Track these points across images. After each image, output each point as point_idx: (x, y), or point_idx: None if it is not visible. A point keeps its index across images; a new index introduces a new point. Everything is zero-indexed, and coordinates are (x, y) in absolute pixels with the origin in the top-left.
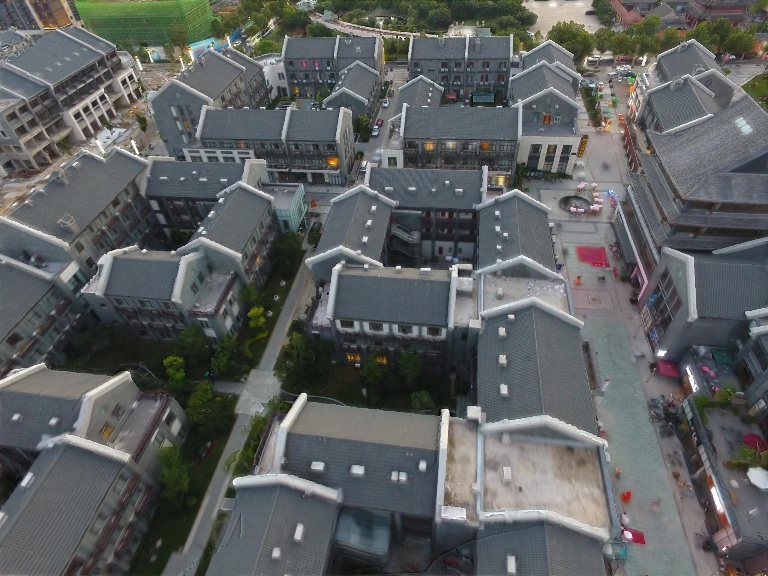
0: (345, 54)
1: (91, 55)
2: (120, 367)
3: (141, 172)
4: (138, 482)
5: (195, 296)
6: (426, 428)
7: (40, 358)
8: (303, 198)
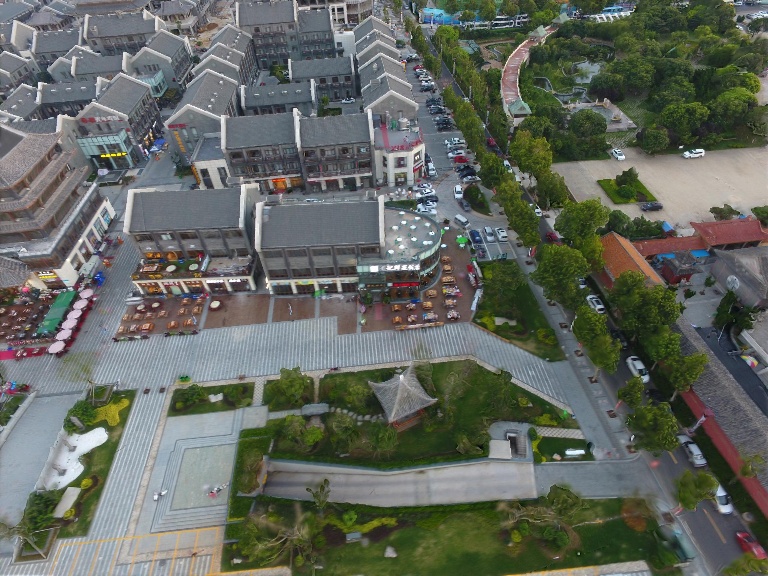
0: None
1: None
2: None
3: (151, 33)
4: None
5: (65, 79)
6: None
7: None
8: (154, 87)
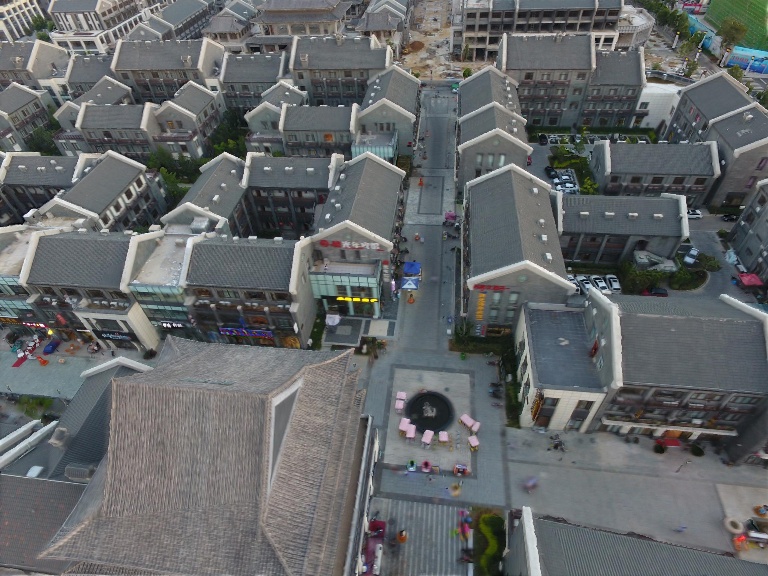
0: (724, 127)
1: (586, 3)
2: (241, 133)
3: (379, 69)
4: (145, 144)
5: (264, 130)
6: (85, 204)
7: (249, 106)
8: (388, 158)
